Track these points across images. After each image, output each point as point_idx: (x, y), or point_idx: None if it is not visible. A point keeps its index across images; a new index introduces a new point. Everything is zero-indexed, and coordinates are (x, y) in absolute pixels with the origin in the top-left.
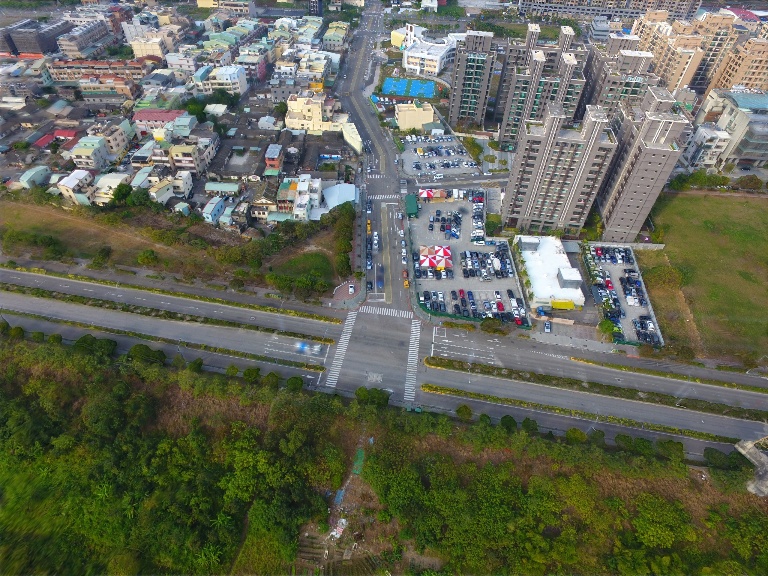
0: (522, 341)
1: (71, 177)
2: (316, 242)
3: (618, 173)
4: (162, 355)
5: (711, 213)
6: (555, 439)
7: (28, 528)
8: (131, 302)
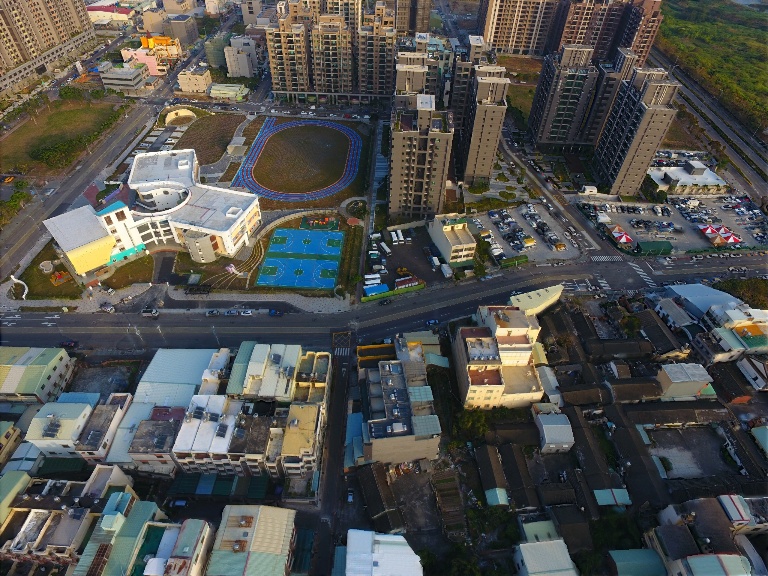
0: (758, 202)
1: None
2: None
3: (605, 110)
4: None
5: None
6: None
7: None
8: None
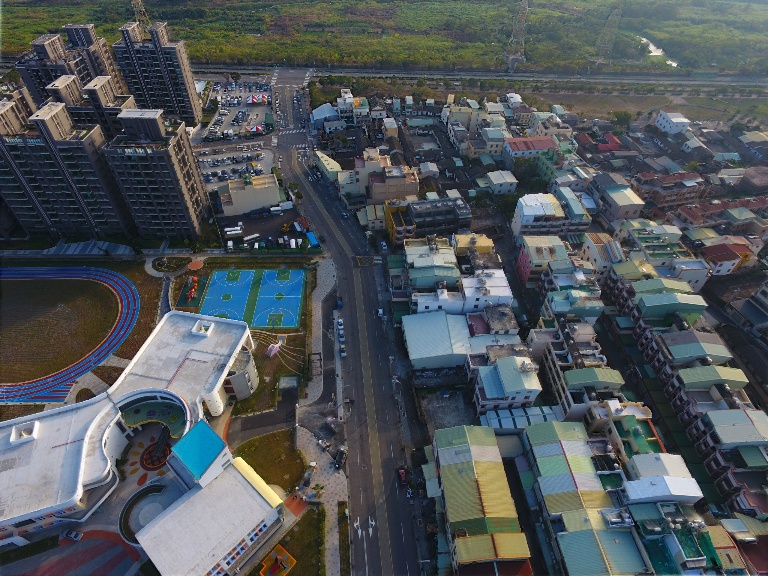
0: None
1: (516, 97)
2: (335, 106)
3: None
4: (380, 62)
5: None
6: (223, 63)
7: None
8: None
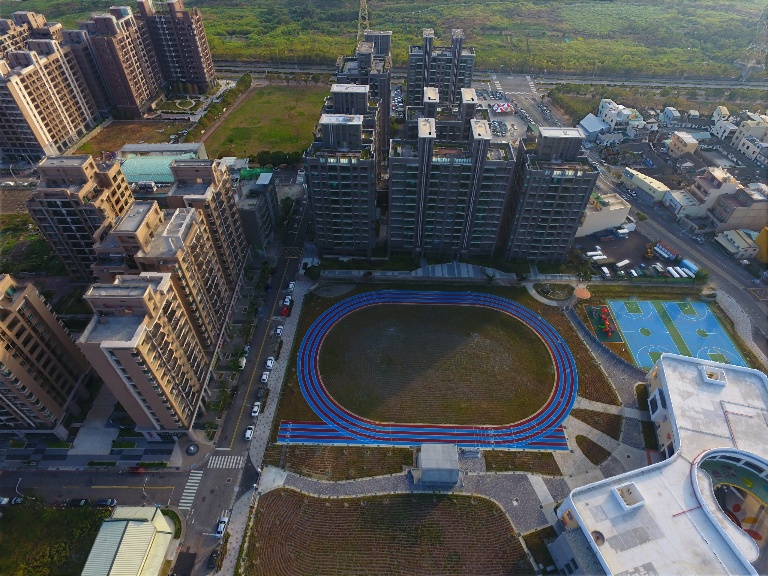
0: None
1: None
2: None
3: None
4: None
5: (284, 148)
6: None
7: (595, 60)
8: (649, 89)
